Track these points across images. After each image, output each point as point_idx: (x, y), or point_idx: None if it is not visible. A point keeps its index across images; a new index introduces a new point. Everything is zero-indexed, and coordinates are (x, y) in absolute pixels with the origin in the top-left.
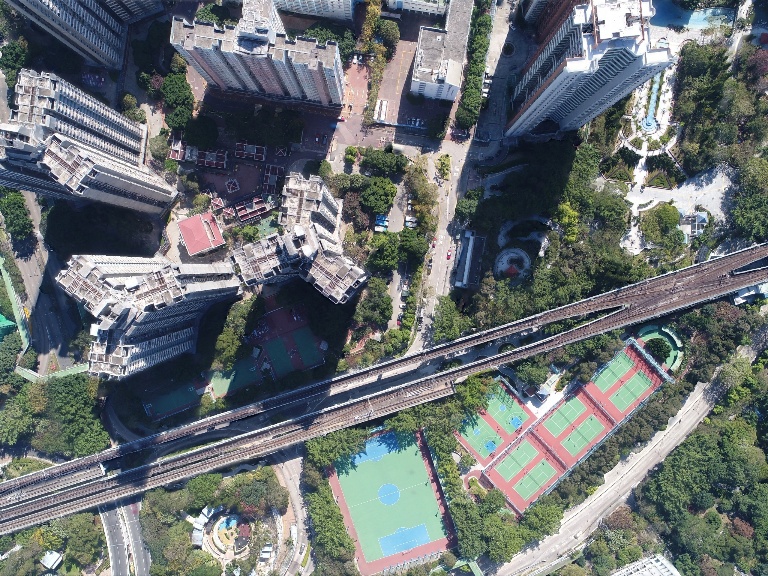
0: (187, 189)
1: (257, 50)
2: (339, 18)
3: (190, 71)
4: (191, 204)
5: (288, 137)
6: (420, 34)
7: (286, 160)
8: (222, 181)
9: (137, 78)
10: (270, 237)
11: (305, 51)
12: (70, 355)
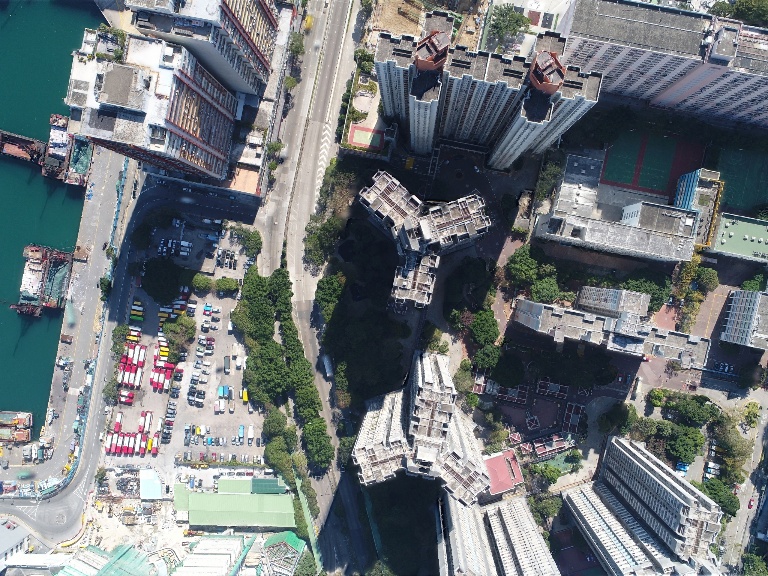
0: (488, 424)
1: (631, 347)
2: (651, 259)
3: (494, 303)
4: (486, 434)
5: (600, 384)
6: (758, 299)
7: (586, 397)
8: (519, 414)
9: (445, 312)
10: (667, 567)
11: (675, 346)
12: (356, 575)
